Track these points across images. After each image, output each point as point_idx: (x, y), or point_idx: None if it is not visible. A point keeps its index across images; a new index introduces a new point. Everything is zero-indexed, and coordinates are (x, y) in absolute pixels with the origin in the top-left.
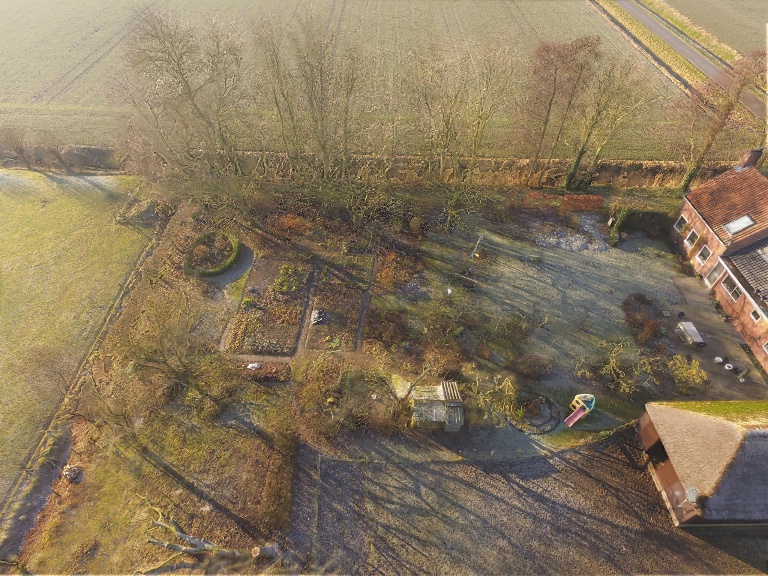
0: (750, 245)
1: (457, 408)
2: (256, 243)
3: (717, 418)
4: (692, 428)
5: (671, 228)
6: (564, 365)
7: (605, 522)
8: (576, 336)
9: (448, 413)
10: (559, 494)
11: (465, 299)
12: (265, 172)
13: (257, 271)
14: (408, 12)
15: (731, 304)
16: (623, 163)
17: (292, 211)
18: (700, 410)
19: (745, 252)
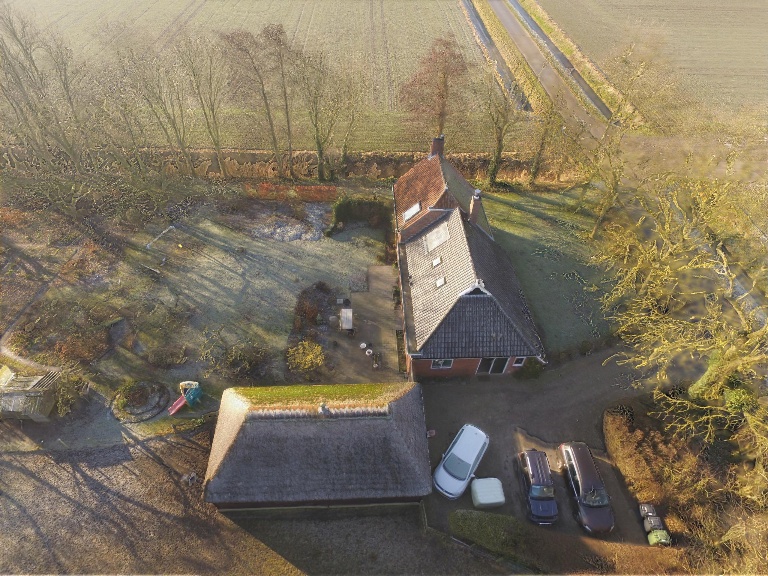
0: (420, 232)
1: (37, 398)
2: None
3: (248, 401)
4: (230, 412)
5: (393, 217)
6: None
7: (148, 509)
8: (236, 325)
9: (26, 403)
10: (119, 482)
11: (143, 290)
12: None
13: None
14: (266, 8)
15: None
16: (395, 155)
17: (20, 204)
18: (255, 394)
19: (415, 239)
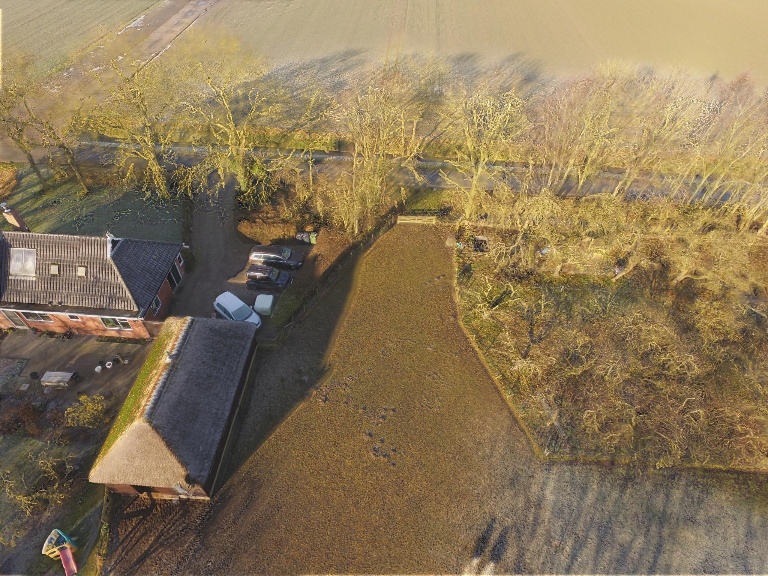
0: None
1: None
2: None
3: (126, 430)
4: (126, 455)
5: None
6: None
7: (182, 574)
8: None
9: None
10: None
11: None
12: None
13: None
14: None
15: (54, 325)
16: None
17: None
18: (116, 435)
19: (4, 287)
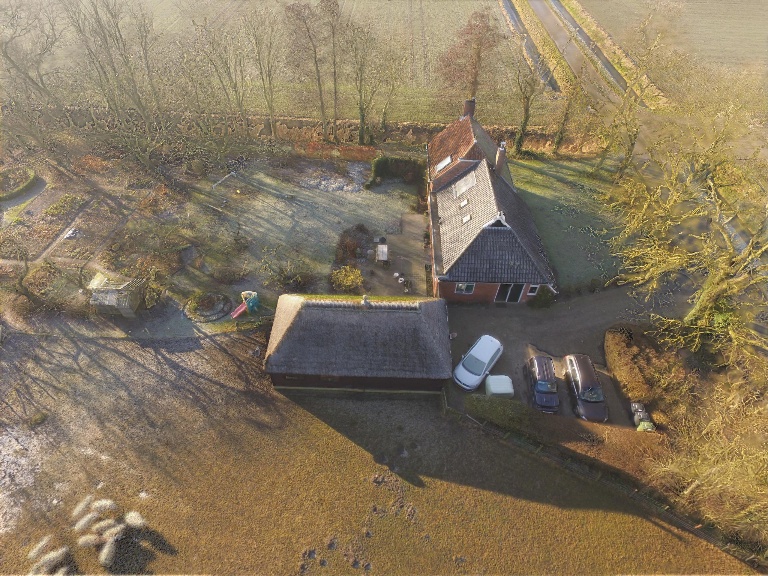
0: (450, 181)
1: (127, 295)
2: (54, 178)
3: (302, 297)
4: (286, 306)
5: (425, 175)
6: (260, 275)
7: (217, 383)
8: (287, 255)
9: (119, 298)
10: (192, 363)
11: None
12: (95, 124)
13: (41, 198)
14: None
15: None
16: (429, 125)
17: (100, 155)
18: None
19: (445, 188)
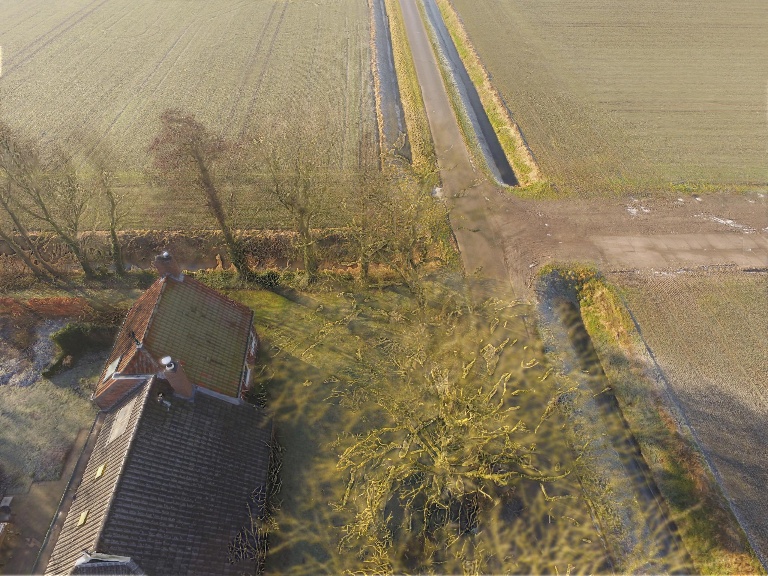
0: (120, 400)
1: None
2: None
3: None
4: None
5: None
6: None
7: None
8: None
9: None
10: None
11: None
12: None
13: None
14: (142, 31)
15: None
16: None
17: None
18: None
19: (113, 411)
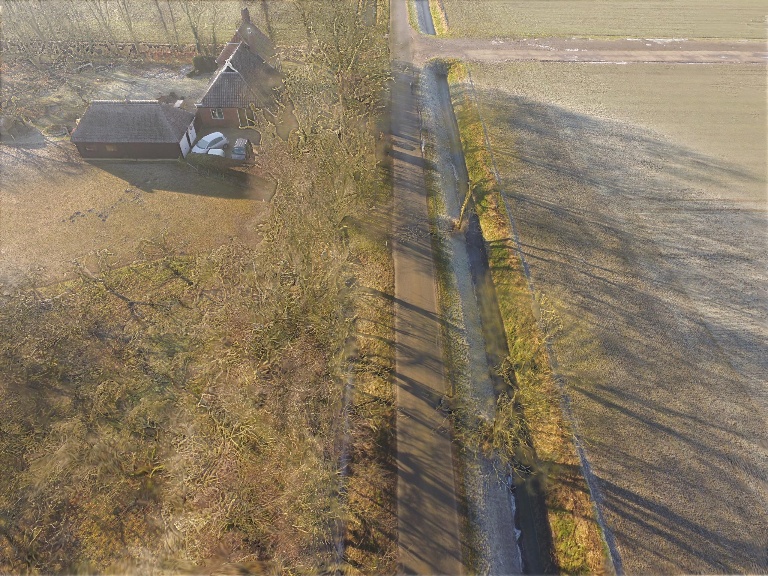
0: None
1: (2, 118)
2: None
3: None
4: None
5: None
6: None
7: (50, 159)
8: None
9: None
10: None
11: (71, 96)
12: None
13: None
14: None
15: None
16: None
17: (8, 64)
18: None
19: None
